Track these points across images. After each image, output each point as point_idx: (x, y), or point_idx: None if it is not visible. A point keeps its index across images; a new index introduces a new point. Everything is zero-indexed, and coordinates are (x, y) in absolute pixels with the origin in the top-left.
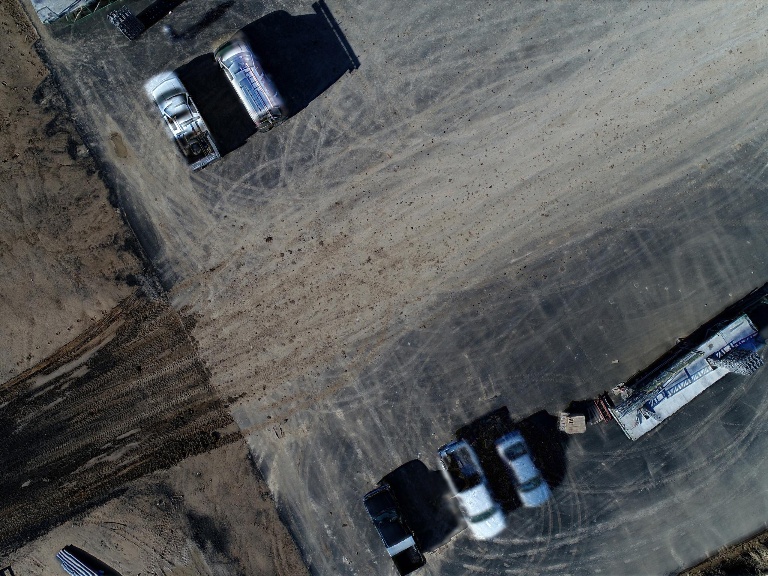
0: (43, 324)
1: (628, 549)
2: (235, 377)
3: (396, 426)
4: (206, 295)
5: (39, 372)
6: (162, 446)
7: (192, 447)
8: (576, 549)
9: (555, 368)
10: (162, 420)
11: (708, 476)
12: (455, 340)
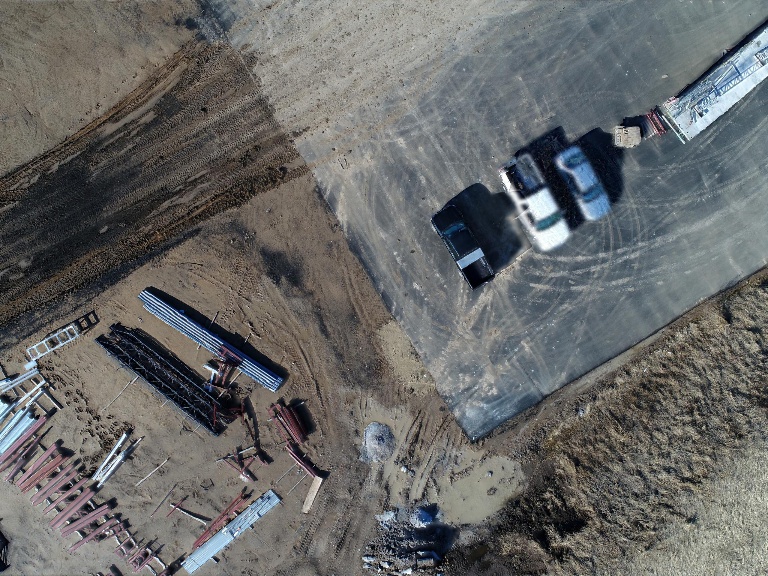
0: (108, 73)
1: (688, 260)
2: (298, 112)
3: (456, 151)
4: (265, 33)
5: (108, 120)
6: (232, 185)
7: (261, 184)
8: (637, 263)
9: (607, 86)
10: (230, 159)
11: (761, 184)
12: (508, 63)
